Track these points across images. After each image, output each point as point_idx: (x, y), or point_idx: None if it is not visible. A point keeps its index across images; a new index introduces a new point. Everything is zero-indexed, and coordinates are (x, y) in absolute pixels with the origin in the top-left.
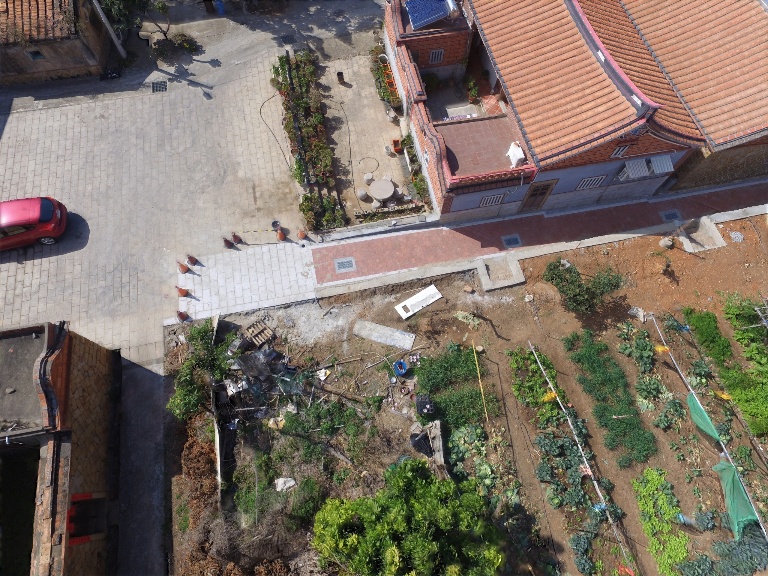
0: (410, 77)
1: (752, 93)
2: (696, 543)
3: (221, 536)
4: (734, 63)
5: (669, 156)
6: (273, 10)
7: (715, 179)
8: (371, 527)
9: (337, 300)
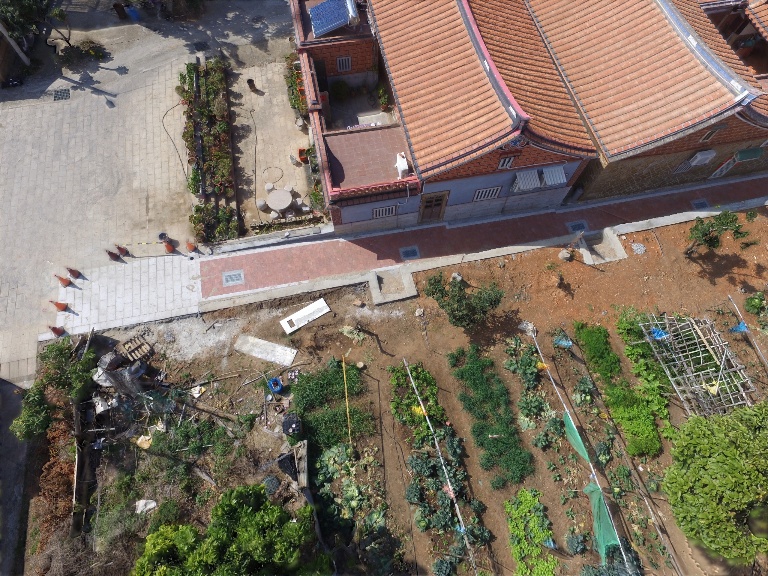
0: (306, 86)
1: (649, 102)
2: (565, 567)
3: (56, 563)
4: (634, 72)
5: (562, 167)
6: (188, 16)
7: (624, 189)
8: (185, 558)
9: (221, 314)
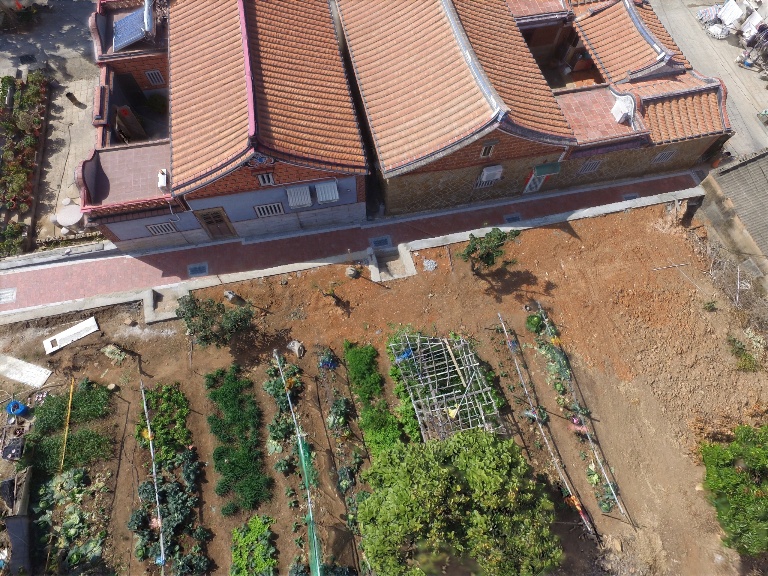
0: (95, 100)
1: (427, 118)
2: None
3: None
4: (421, 86)
5: (334, 183)
6: (19, 29)
7: (431, 204)
8: None
9: None
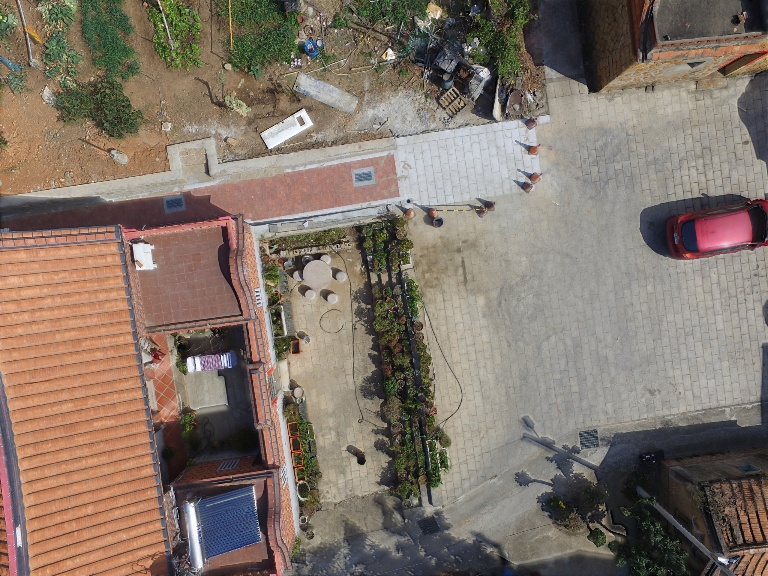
0: (266, 402)
1: None
2: None
3: None
4: None
5: None
6: None
7: None
8: None
9: (373, 136)
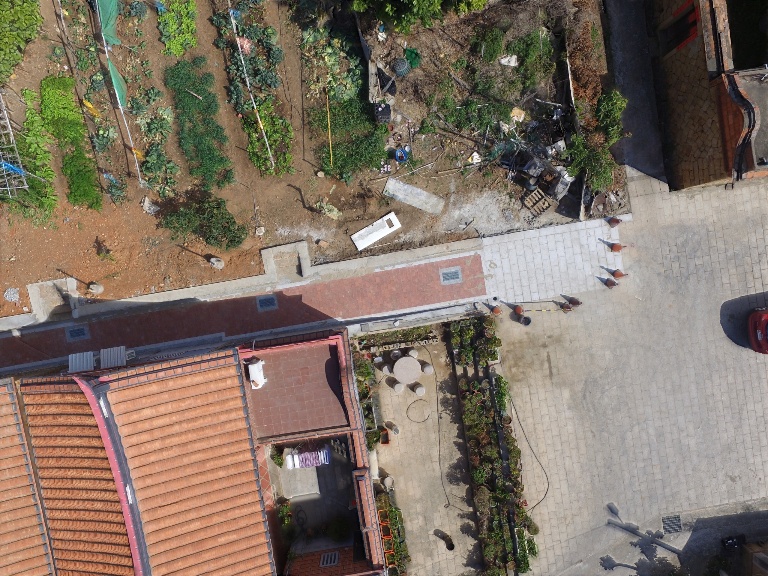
0: (371, 506)
1: None
2: None
3: (568, 0)
4: None
5: None
6: None
7: None
8: None
9: (460, 236)
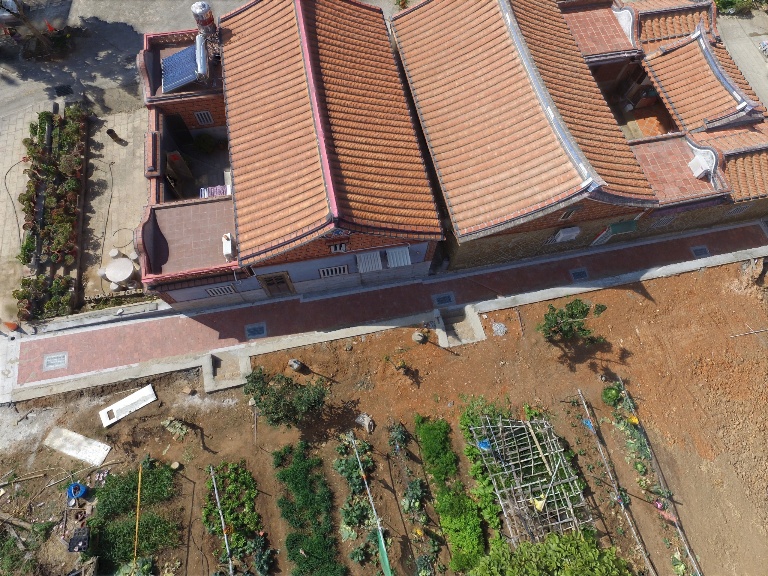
0: (146, 149)
1: (504, 178)
2: None
3: None
4: (495, 141)
5: (406, 248)
6: (53, 56)
7: (496, 259)
8: None
9: (37, 403)
